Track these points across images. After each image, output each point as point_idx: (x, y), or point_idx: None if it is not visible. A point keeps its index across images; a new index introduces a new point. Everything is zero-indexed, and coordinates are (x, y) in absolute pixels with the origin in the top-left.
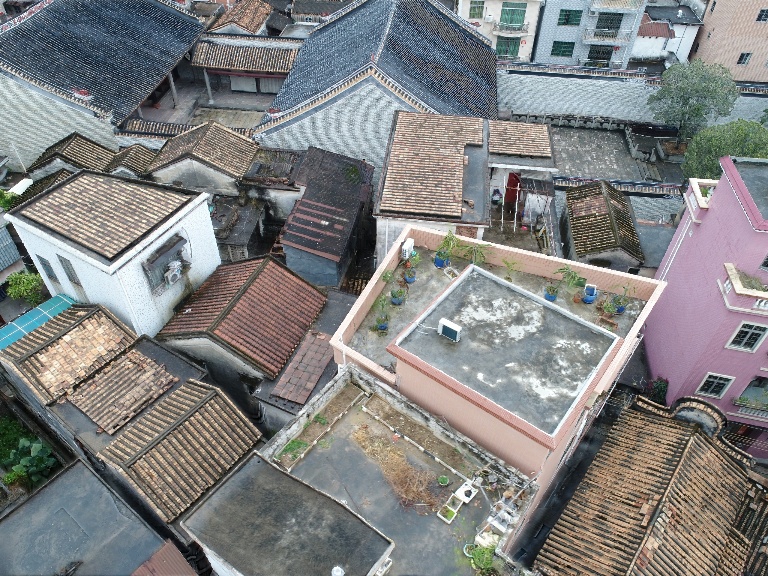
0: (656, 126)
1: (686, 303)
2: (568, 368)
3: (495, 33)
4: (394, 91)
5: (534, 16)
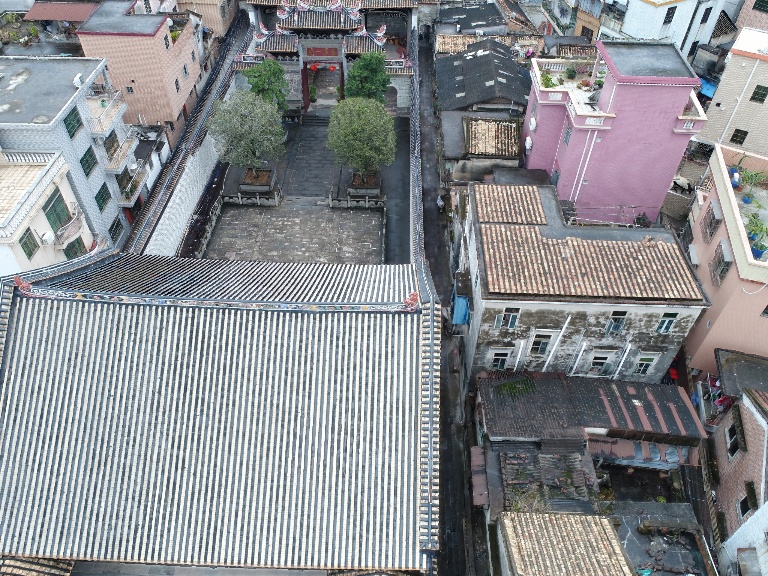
0: (212, 181)
1: (630, 170)
2: None
3: (65, 246)
4: None
5: (69, 191)
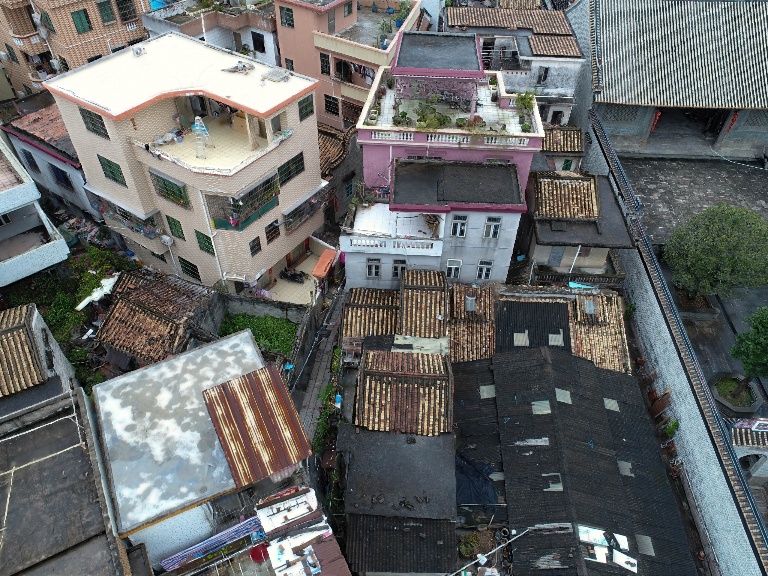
0: None
1: None
2: (307, 0)
3: None
4: (590, 8)
5: None
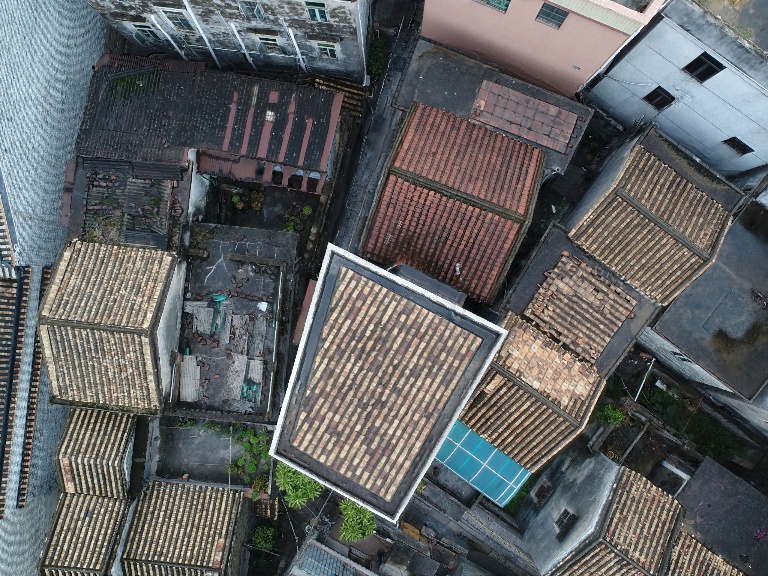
0: None
1: None
2: None
3: None
4: None
5: None
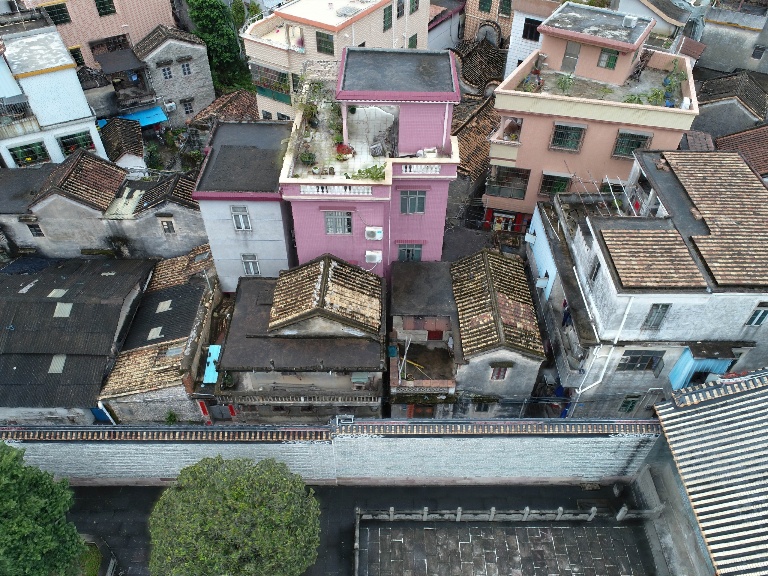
0: None
1: None
2: (564, 19)
3: None
4: None
5: None
